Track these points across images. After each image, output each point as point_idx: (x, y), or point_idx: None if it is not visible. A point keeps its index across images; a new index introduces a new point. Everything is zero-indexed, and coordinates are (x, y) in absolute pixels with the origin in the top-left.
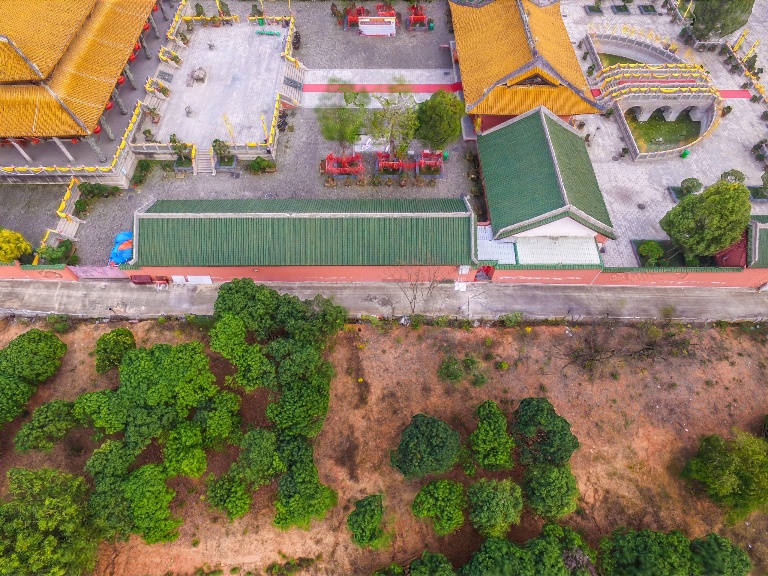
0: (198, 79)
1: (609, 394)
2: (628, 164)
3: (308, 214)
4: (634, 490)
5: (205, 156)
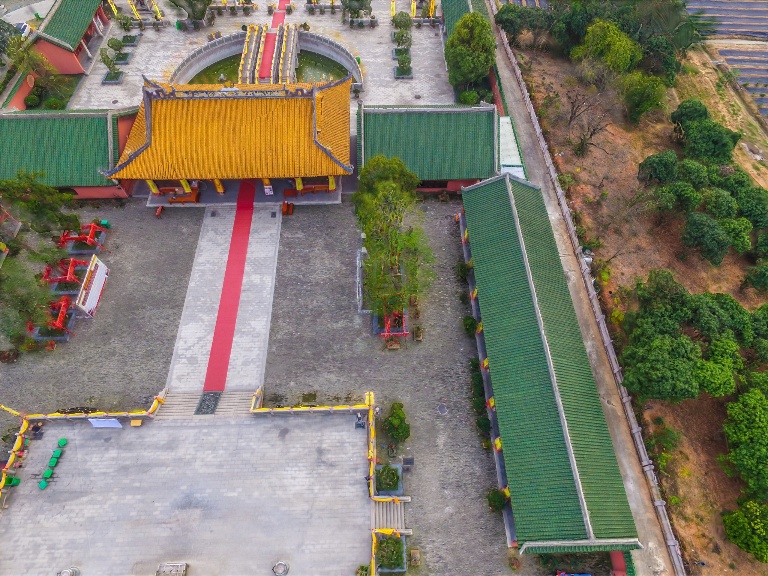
0: (184, 575)
1: None
2: (367, 95)
3: None
4: (648, 150)
5: (381, 516)
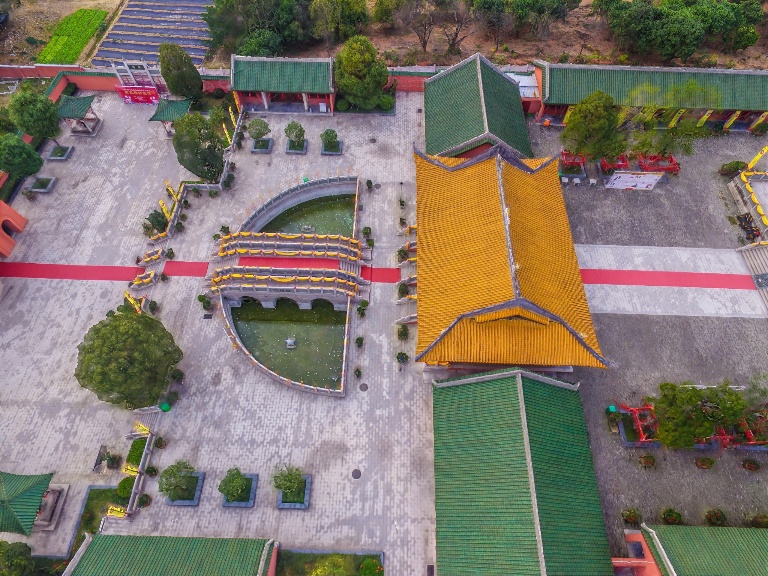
0: None
1: (439, 47)
2: None
3: (672, 68)
4: None
5: None
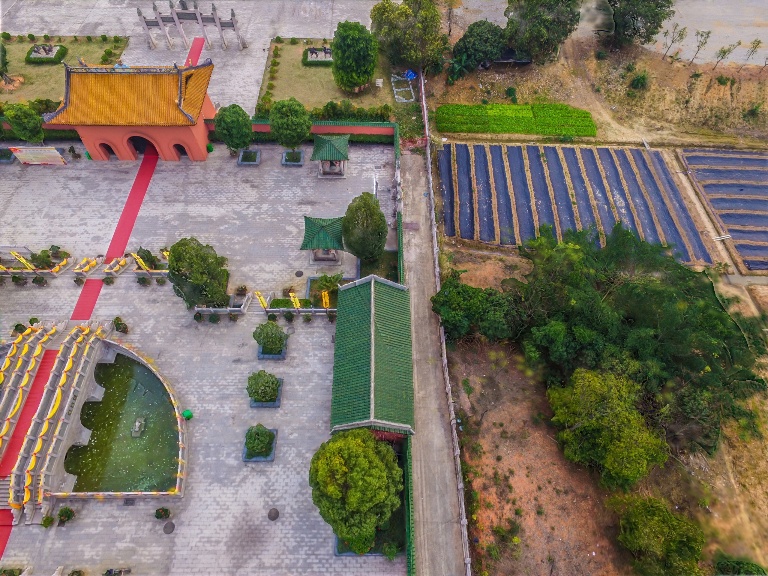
0: None
1: None
2: (185, 509)
3: None
4: None
5: None
